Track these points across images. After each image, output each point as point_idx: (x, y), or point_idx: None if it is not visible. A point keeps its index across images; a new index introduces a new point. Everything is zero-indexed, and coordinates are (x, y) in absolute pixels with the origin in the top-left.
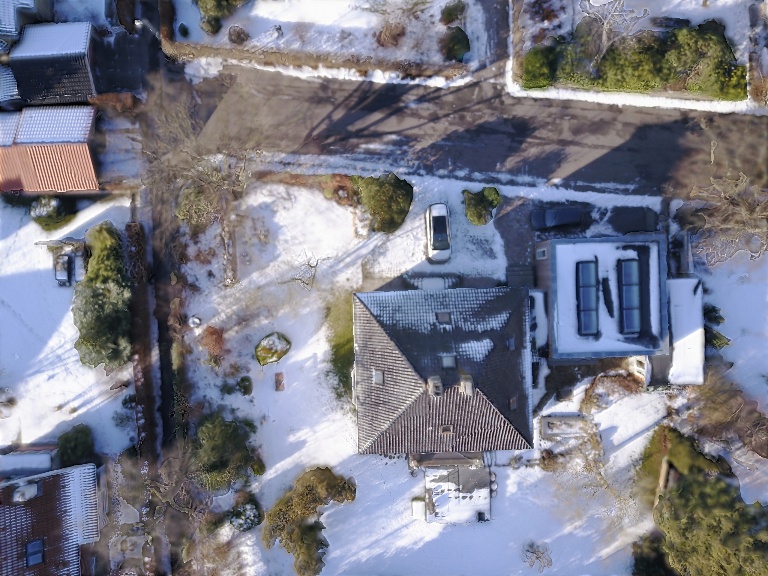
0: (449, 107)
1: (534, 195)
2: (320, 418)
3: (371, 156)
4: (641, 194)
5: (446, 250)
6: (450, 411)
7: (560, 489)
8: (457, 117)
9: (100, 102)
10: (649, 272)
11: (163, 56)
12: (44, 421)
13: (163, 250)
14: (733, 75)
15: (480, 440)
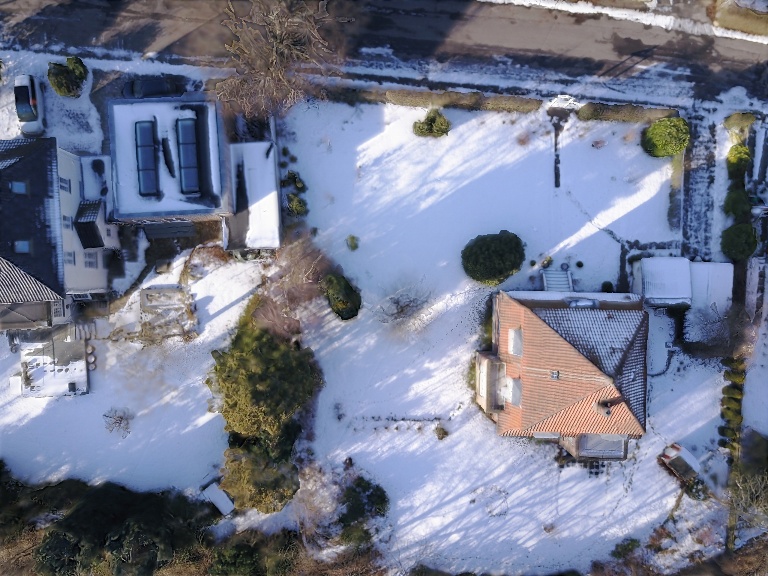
0: None
1: (130, 69)
2: None
3: None
4: None
5: (33, 122)
6: None
7: (157, 360)
8: None
9: None
10: (208, 132)
11: None
12: None
13: None
14: None
15: (3, 289)
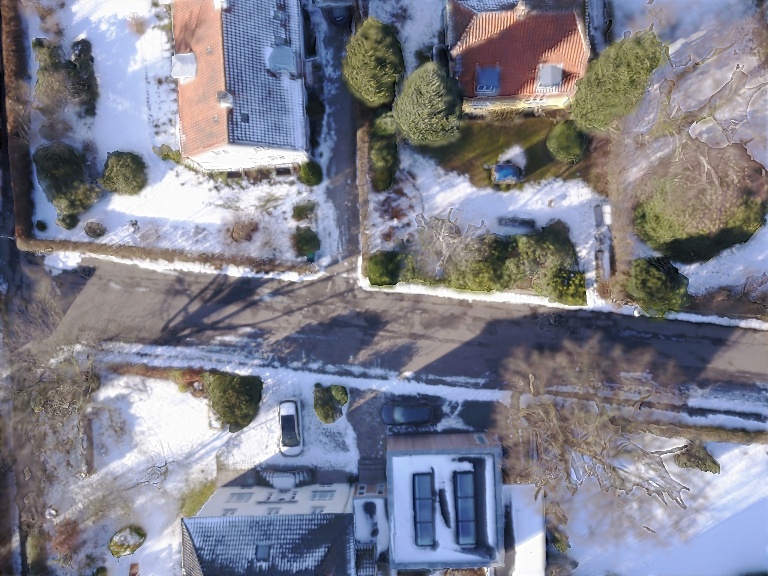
0: (303, 300)
1: (386, 388)
2: None
3: (227, 348)
4: (492, 388)
5: (296, 447)
6: None
7: None
8: (311, 310)
9: None
10: (485, 483)
11: None
12: None
13: (23, 438)
14: (571, 284)
15: None
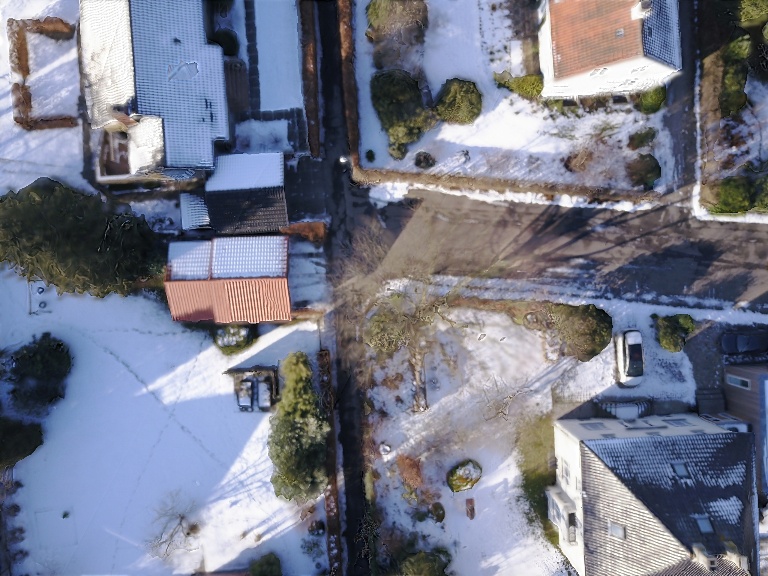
0: (636, 231)
1: (722, 318)
2: (512, 543)
3: (558, 280)
4: None
5: (640, 376)
6: (701, 571)
7: None
8: (644, 240)
9: (292, 232)
10: None
11: (347, 180)
12: (227, 549)
13: (348, 375)
14: None
15: None
